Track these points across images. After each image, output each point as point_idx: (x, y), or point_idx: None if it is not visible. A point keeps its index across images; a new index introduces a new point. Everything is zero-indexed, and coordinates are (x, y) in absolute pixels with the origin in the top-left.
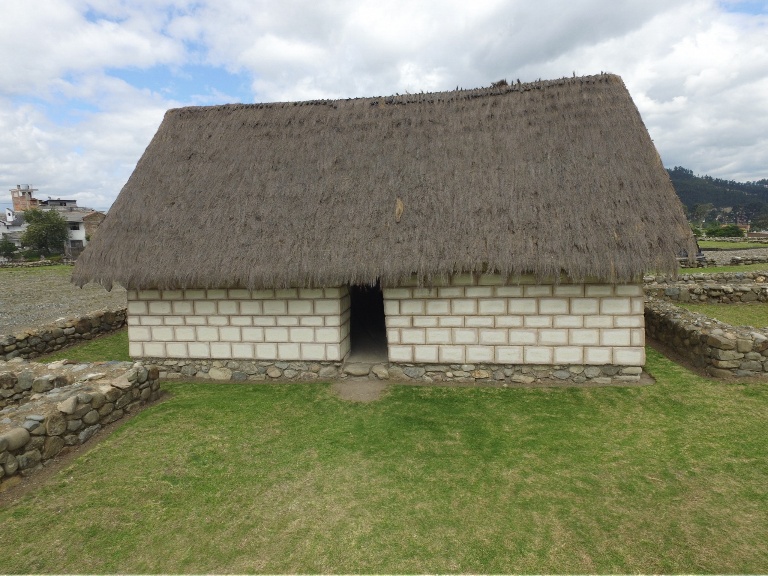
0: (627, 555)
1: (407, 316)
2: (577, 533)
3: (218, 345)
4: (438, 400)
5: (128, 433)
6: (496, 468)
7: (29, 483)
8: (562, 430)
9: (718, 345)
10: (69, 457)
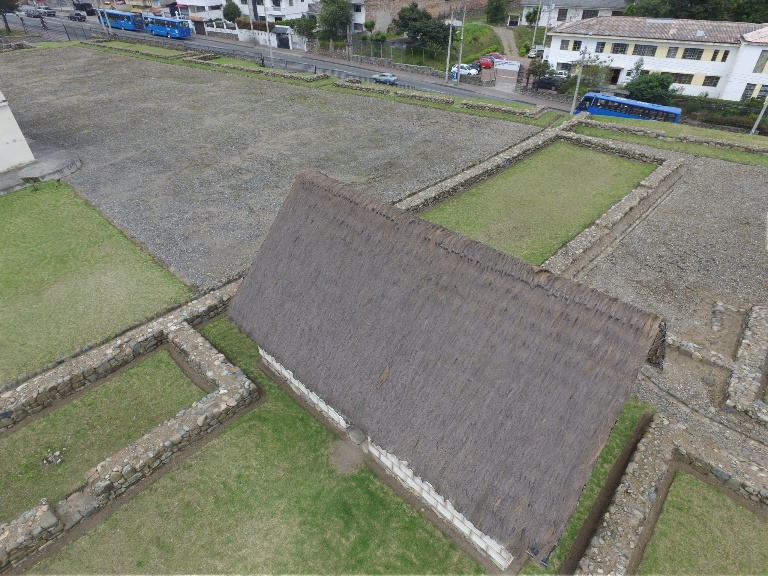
0: None
1: None
2: None
3: (293, 378)
4: (374, 497)
5: (226, 437)
6: None
7: (183, 456)
8: None
9: None
10: (201, 442)
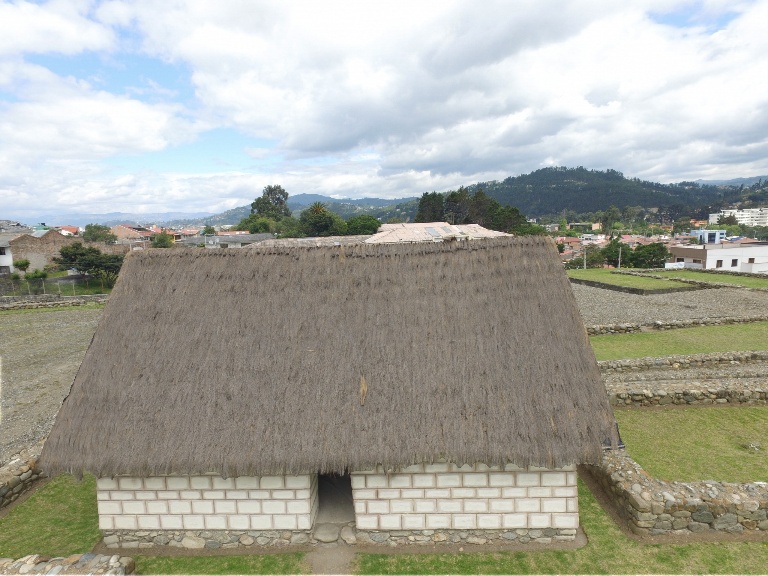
0: None
1: (372, 489)
2: None
3: (191, 517)
4: (403, 575)
5: None
6: None
7: None
8: None
9: (637, 507)
10: None
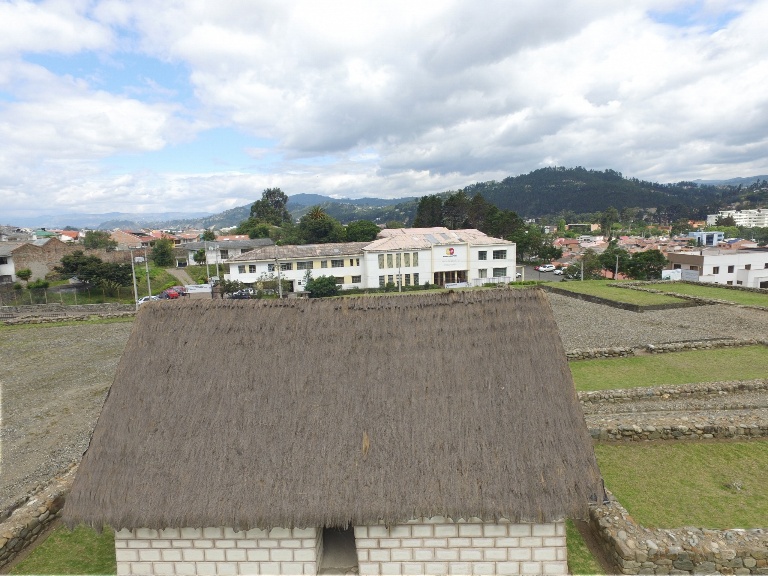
0: None
1: (374, 539)
2: None
3: (204, 564)
4: None
5: None
6: None
7: None
8: None
9: (622, 555)
10: None
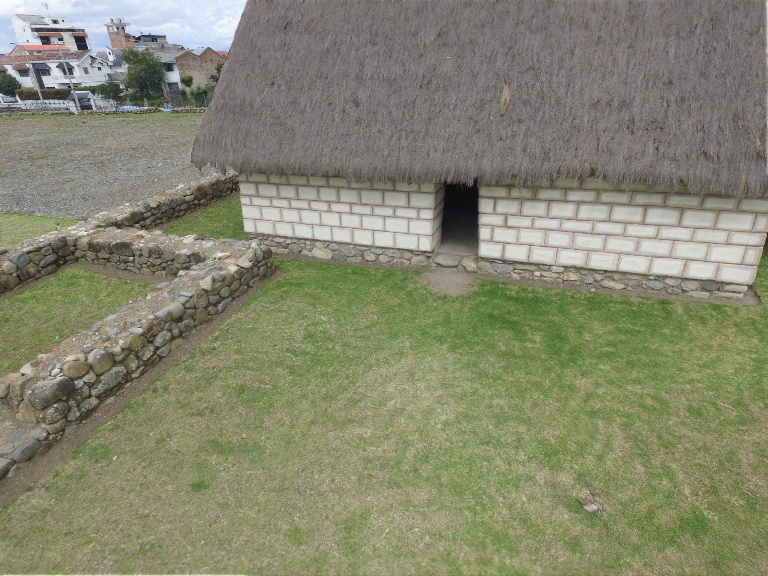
0: (679, 471)
1: (501, 215)
2: (636, 445)
3: (320, 228)
4: (523, 299)
5: (254, 307)
6: (570, 375)
7: (189, 343)
8: (643, 344)
9: None
10: (213, 324)
